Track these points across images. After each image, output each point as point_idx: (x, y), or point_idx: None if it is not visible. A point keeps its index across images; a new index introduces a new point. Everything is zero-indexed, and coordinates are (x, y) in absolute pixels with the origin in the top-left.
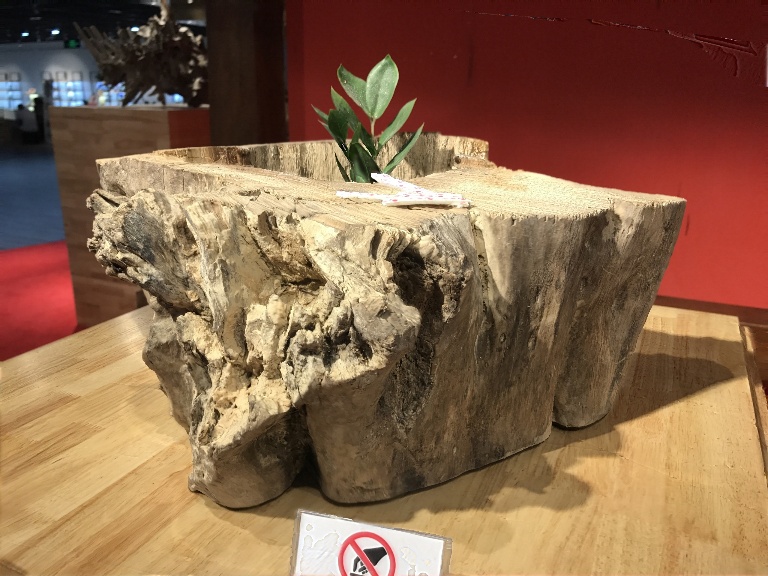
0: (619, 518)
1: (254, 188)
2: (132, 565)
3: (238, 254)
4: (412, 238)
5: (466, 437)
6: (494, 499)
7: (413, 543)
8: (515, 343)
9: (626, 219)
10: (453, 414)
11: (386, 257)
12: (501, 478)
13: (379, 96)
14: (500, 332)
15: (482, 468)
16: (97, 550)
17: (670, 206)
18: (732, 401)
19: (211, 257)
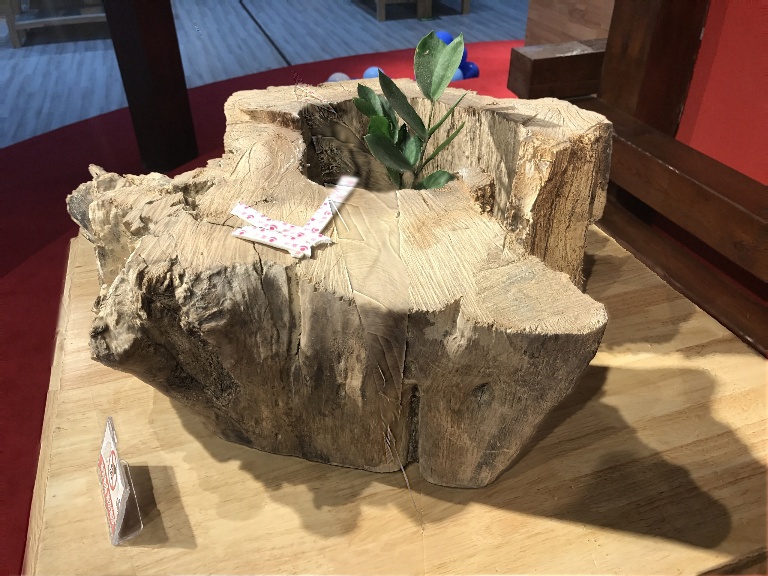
0: (326, 567)
1: (205, 179)
2: (93, 390)
3: (117, 243)
4: (175, 283)
5: (290, 432)
6: (283, 487)
7: (118, 478)
8: (324, 386)
9: (458, 328)
10: (267, 412)
11: (146, 292)
12: (314, 477)
13: (445, 76)
14: (303, 372)
15: (312, 461)
16: (95, 371)
17: (522, 335)
18: (643, 567)
19: (96, 242)
